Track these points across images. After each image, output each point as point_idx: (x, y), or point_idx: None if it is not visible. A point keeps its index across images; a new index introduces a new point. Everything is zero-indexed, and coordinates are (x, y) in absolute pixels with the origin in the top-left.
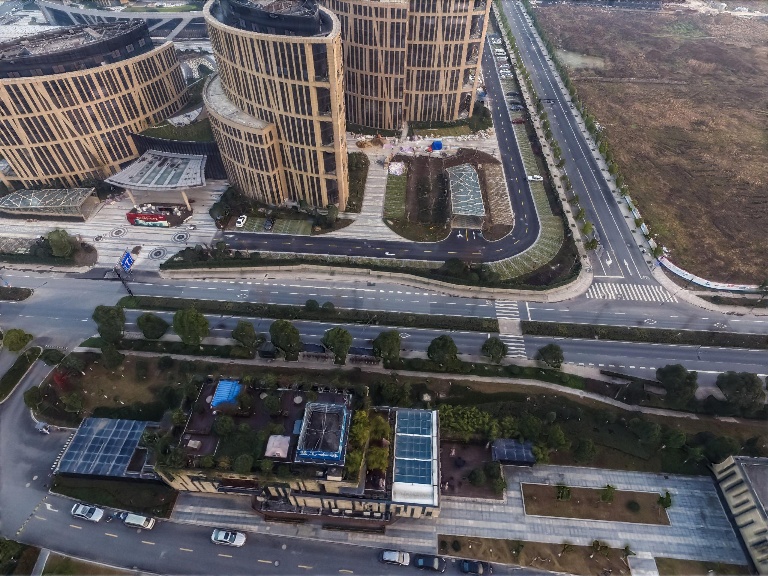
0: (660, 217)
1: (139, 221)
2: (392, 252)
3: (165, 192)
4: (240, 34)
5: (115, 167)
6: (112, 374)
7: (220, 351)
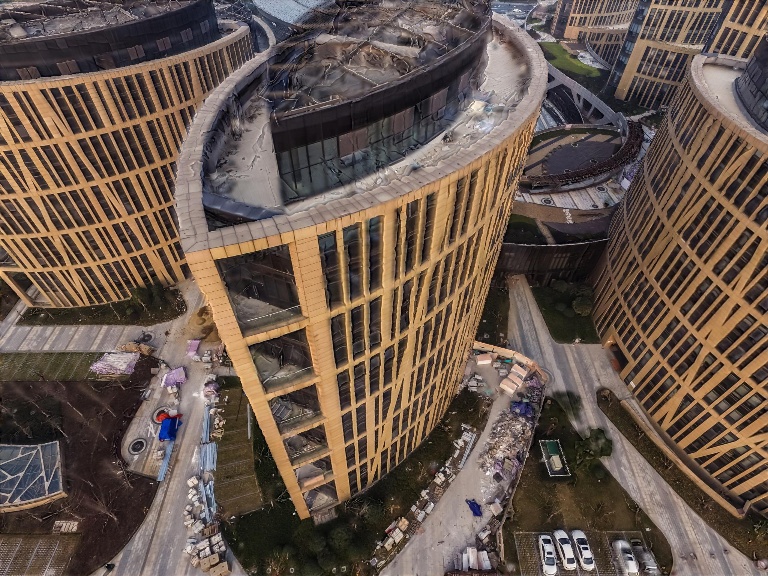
0: None
1: None
2: None
3: None
4: None
5: None
6: None
7: None
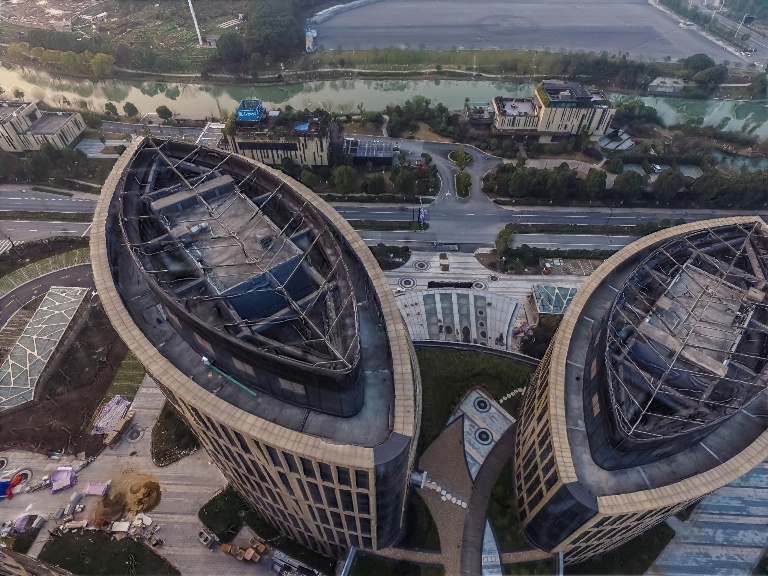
0: None
1: None
2: None
3: None
4: None
5: None
6: None
7: None
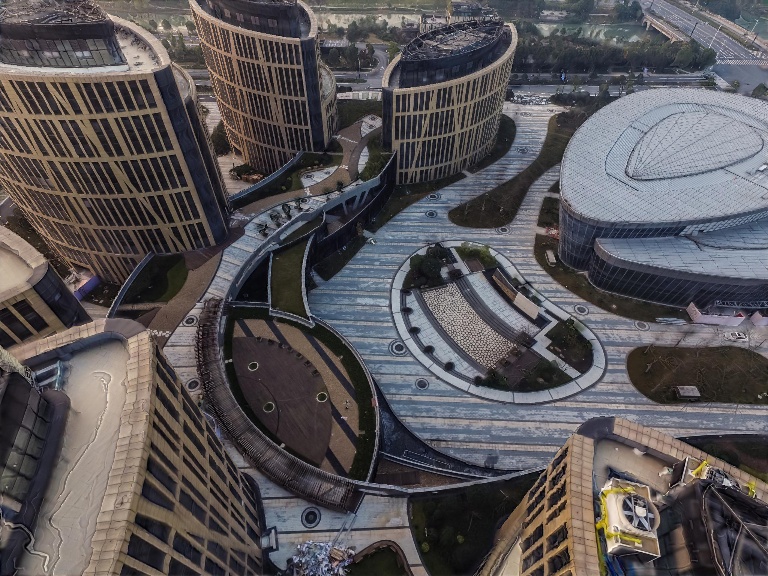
0: None
1: None
2: (211, 97)
3: None
4: None
5: None
6: None
7: None
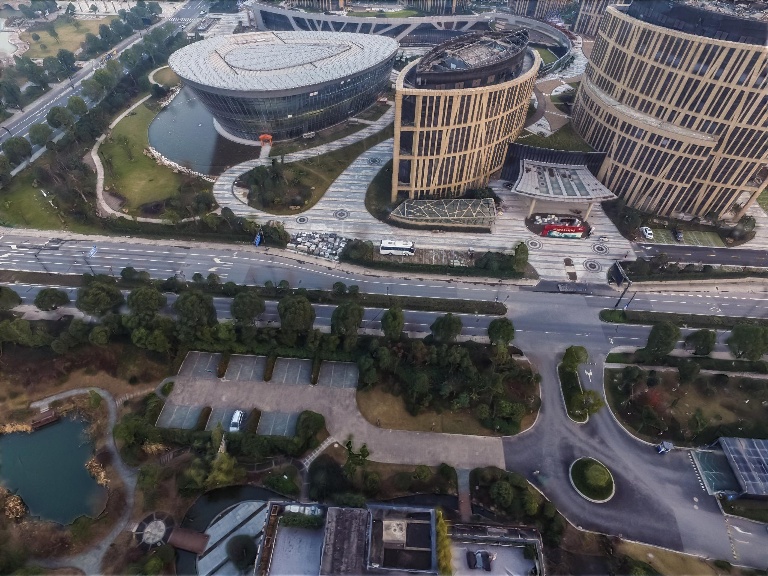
0: None
1: (553, 232)
2: None
3: (552, 203)
4: (742, 47)
5: (487, 177)
6: (675, 391)
7: (757, 367)
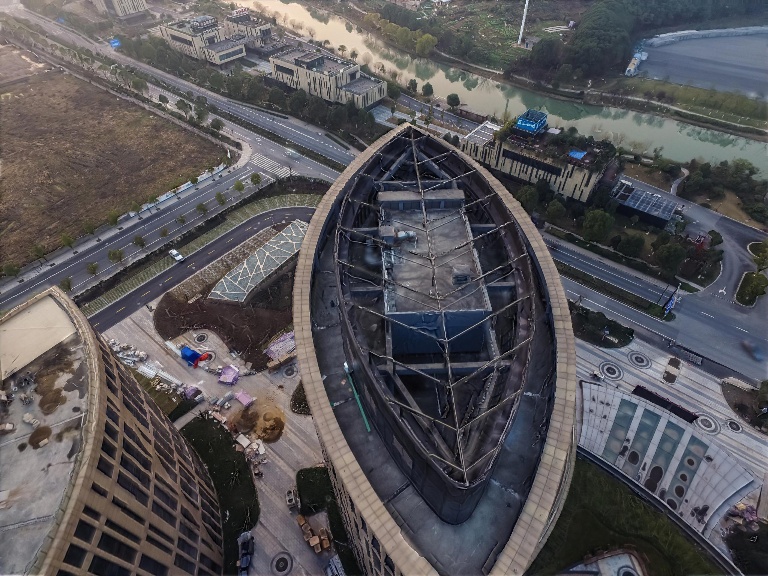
0: (161, 187)
1: None
2: None
3: None
4: None
5: None
6: None
7: None
